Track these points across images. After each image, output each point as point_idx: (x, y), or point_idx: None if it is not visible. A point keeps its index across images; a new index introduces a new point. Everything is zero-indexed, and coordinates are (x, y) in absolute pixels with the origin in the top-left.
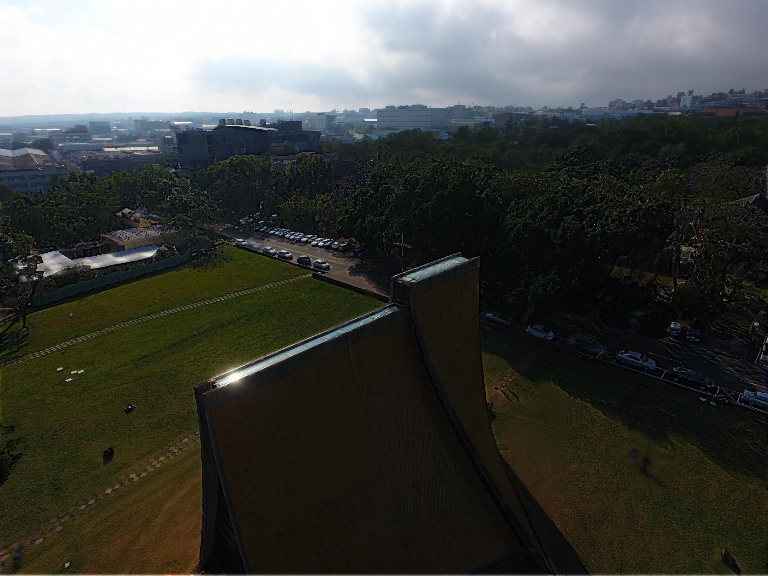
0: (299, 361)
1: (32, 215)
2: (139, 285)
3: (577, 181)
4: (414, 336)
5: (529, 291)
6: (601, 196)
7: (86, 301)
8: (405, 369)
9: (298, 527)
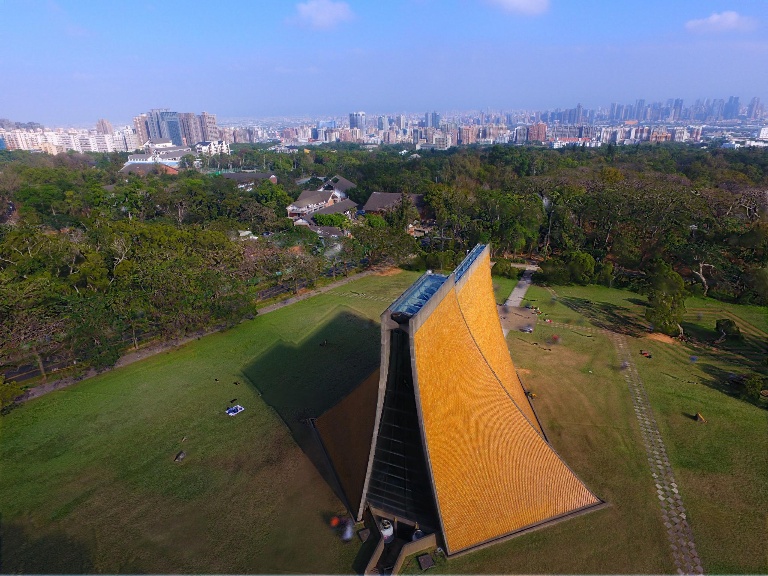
0: None
1: None
2: None
3: None
4: None
5: None
6: None
7: None
8: None
9: None
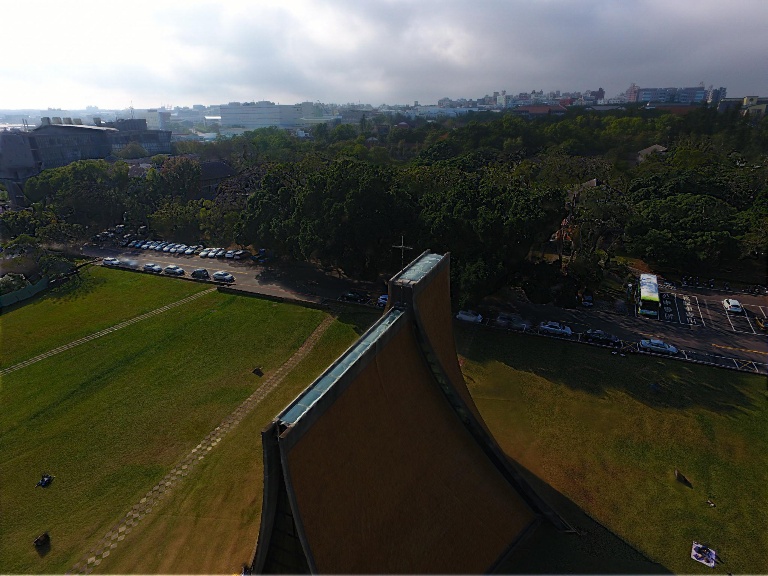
0: (345, 381)
1: None
2: None
3: None
4: (415, 337)
5: (460, 279)
6: (503, 187)
7: None
8: (414, 371)
9: (366, 556)
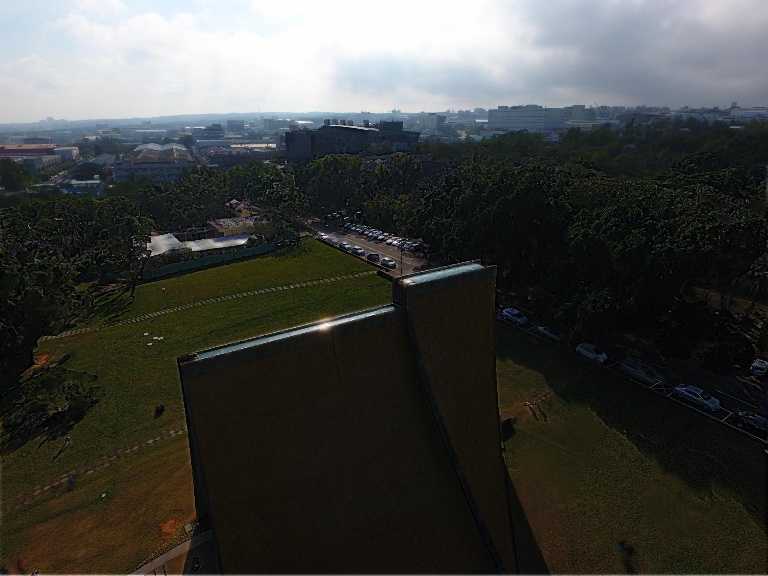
0: (278, 347)
1: (157, 202)
2: (227, 268)
3: (666, 191)
4: (411, 338)
5: (579, 307)
6: (681, 209)
7: (182, 279)
8: (397, 369)
9: (264, 498)
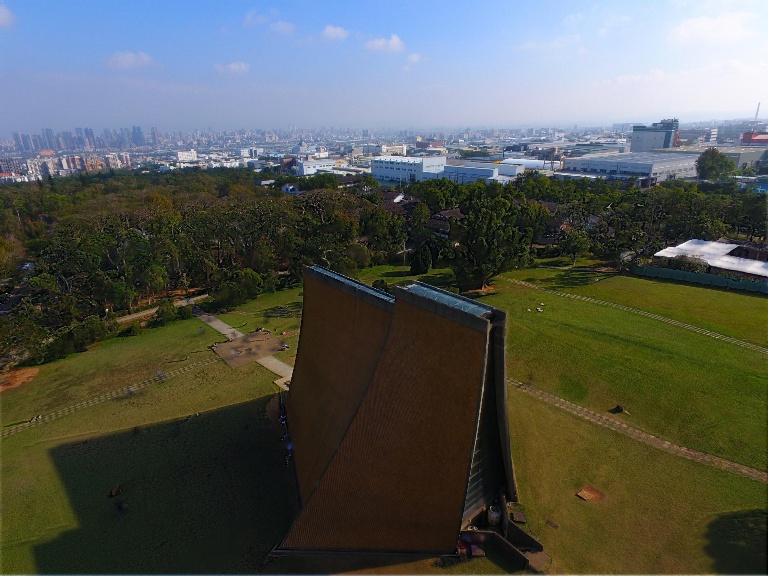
0: None
1: (759, 208)
2: (711, 294)
3: None
4: None
5: None
6: None
7: (657, 285)
8: None
9: None
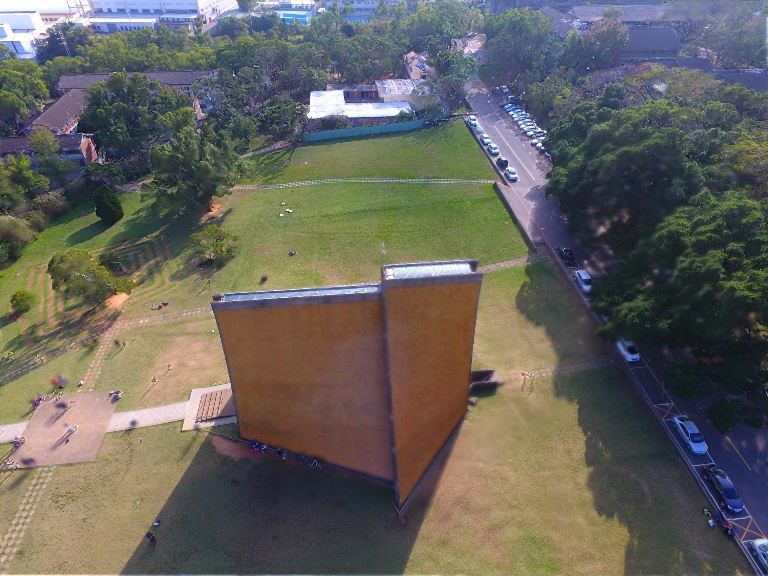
0: (276, 303)
1: (338, 52)
2: (370, 144)
3: None
4: None
5: None
6: None
7: (331, 148)
8: (370, 332)
9: (263, 385)
